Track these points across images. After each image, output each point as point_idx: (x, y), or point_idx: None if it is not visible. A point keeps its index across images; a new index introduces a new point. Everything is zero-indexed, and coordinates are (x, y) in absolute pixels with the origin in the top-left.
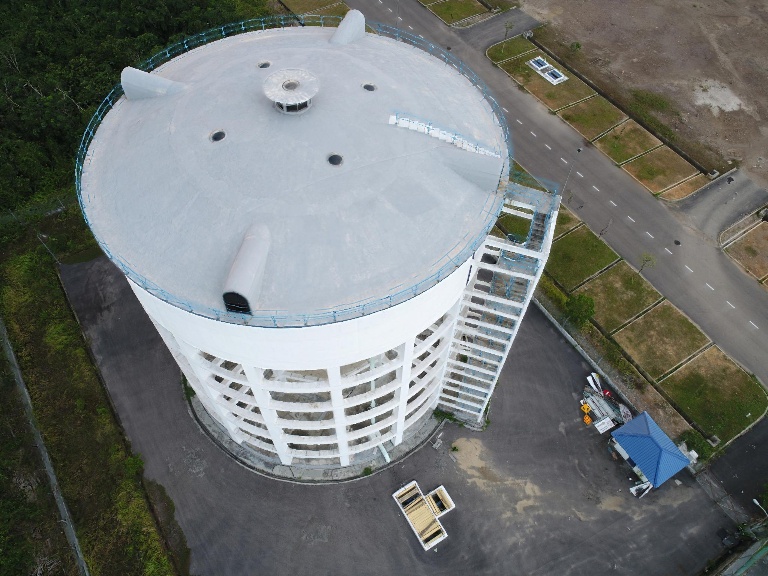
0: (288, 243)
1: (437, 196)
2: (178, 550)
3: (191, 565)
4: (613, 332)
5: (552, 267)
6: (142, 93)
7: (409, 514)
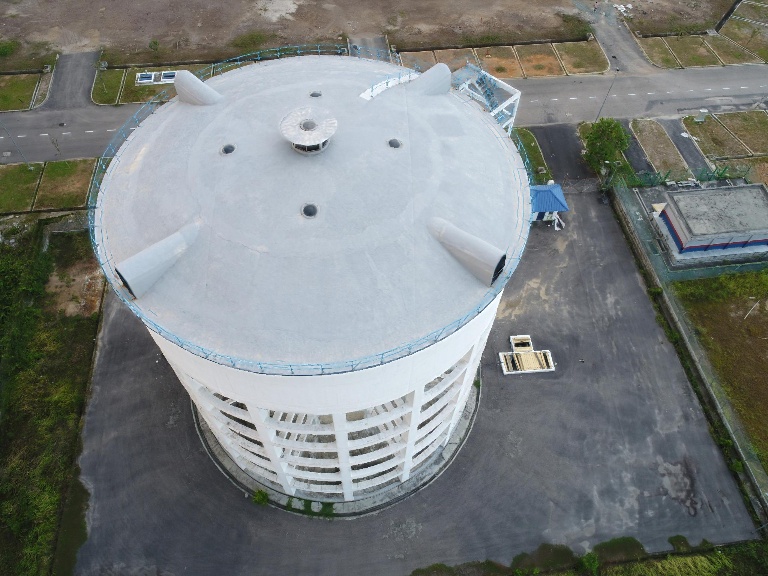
0: (457, 212)
1: (449, 113)
2: (483, 572)
3: (501, 563)
4: None
5: None
6: (159, 272)
7: (524, 368)
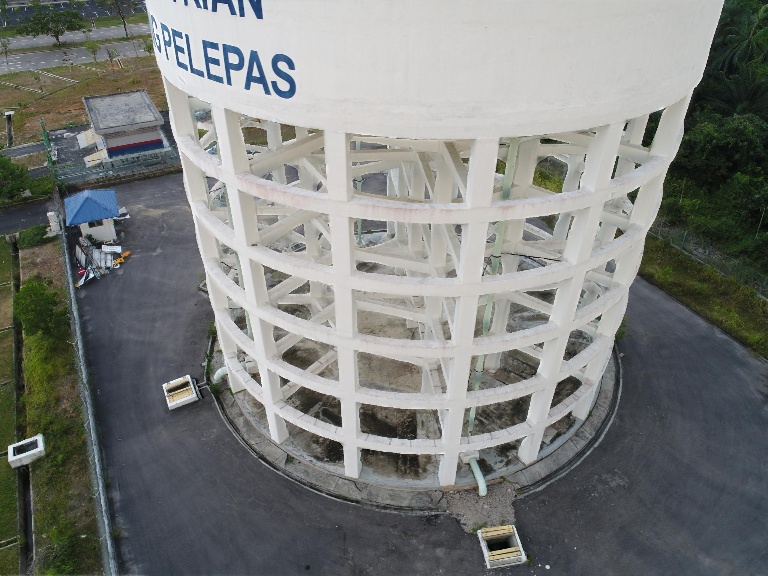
0: None
1: None
2: None
3: None
4: (5, 330)
5: (1, 421)
6: None
7: None
